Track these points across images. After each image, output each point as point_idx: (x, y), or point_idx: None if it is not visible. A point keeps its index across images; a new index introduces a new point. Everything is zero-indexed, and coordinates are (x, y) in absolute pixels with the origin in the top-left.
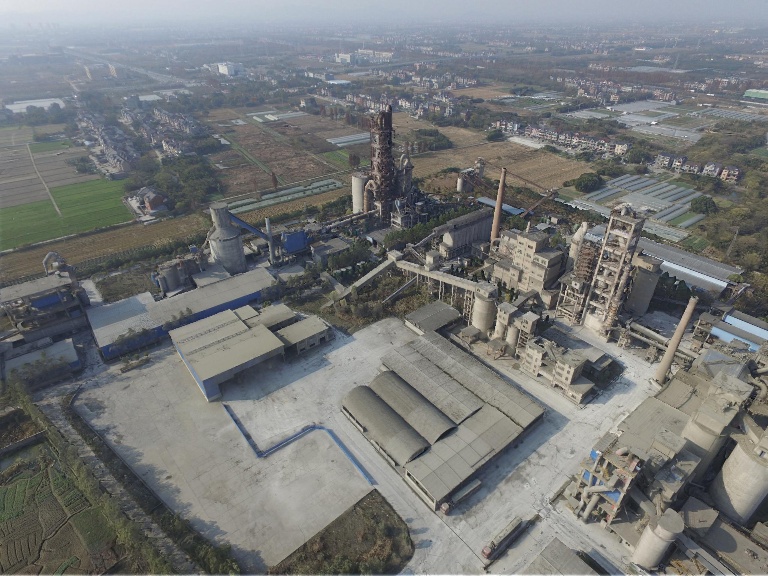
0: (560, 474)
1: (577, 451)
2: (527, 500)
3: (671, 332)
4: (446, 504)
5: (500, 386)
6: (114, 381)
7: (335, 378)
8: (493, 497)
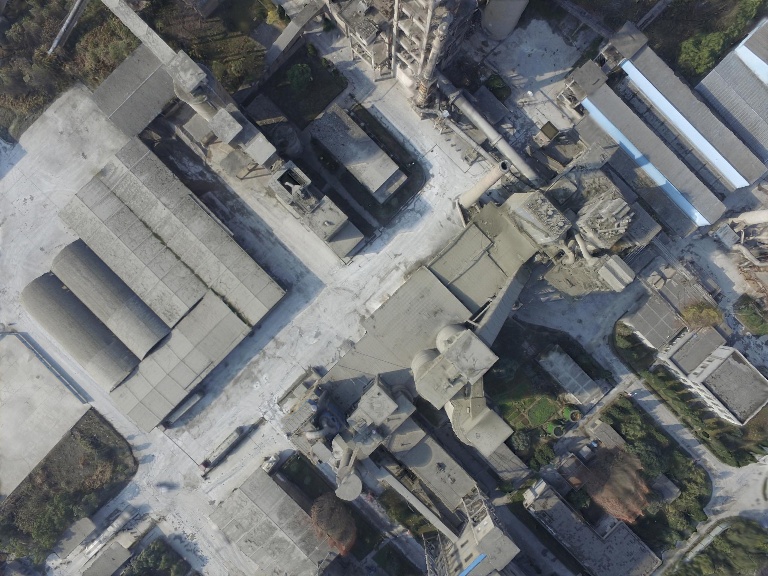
0: (296, 367)
1: (322, 334)
2: (254, 402)
3: (534, 81)
4: (161, 427)
5: (230, 257)
6: None
7: (11, 243)
8: (218, 403)
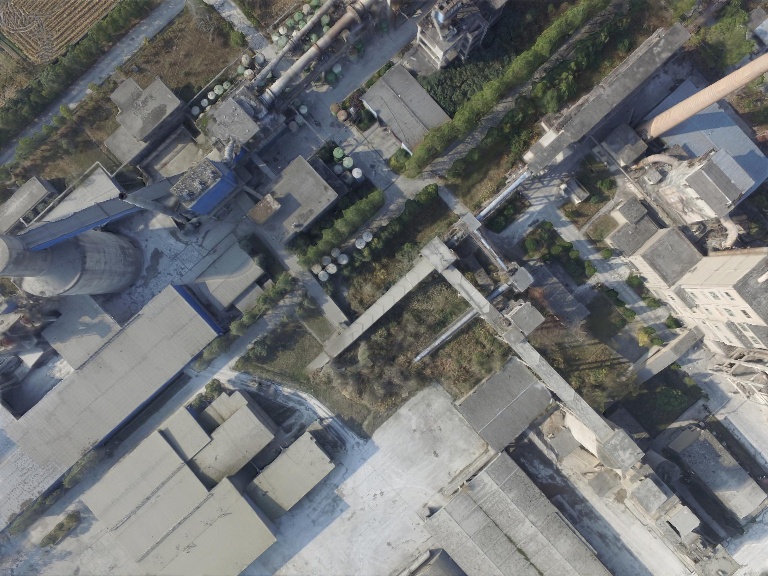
0: None
1: None
2: None
3: None
4: None
5: None
6: (53, 561)
7: (360, 537)
8: None
